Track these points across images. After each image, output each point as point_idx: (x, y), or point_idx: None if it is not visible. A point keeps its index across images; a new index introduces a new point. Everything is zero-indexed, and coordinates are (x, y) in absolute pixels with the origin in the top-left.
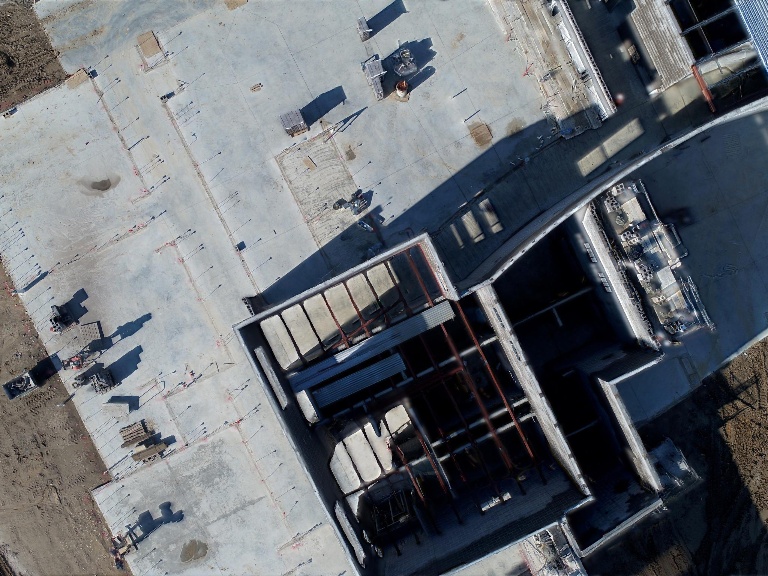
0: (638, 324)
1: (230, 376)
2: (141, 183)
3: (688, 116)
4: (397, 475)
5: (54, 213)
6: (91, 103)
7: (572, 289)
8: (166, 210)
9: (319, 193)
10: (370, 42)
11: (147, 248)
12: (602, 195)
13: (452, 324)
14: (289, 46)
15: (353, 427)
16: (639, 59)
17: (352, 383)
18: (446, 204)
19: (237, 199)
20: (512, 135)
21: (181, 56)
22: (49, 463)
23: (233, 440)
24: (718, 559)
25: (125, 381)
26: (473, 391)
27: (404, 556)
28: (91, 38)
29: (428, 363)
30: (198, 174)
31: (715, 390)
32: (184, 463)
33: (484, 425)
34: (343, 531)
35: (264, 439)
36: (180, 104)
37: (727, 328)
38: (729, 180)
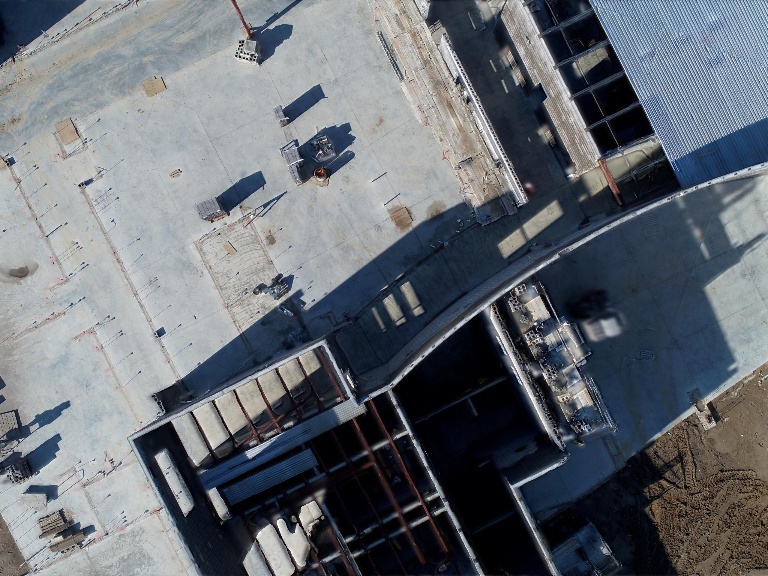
0: (545, 422)
1: None
2: (59, 270)
3: (606, 198)
4: (311, 572)
5: None
6: (9, 190)
7: (494, 372)
8: (85, 297)
9: (239, 278)
10: (289, 127)
11: (66, 335)
12: (505, 295)
13: (364, 418)
14: (208, 132)
15: None
16: (555, 144)
17: (264, 480)
18: (367, 287)
19: (157, 285)
20: (432, 218)
21: (99, 143)
22: None
23: (154, 529)
24: None
25: (43, 470)
26: None
27: None
28: (9, 125)
29: (341, 458)
30: (117, 260)
31: (640, 470)
32: (104, 553)
33: None
34: None
35: None
36: (99, 190)
37: (650, 408)
38: (649, 261)
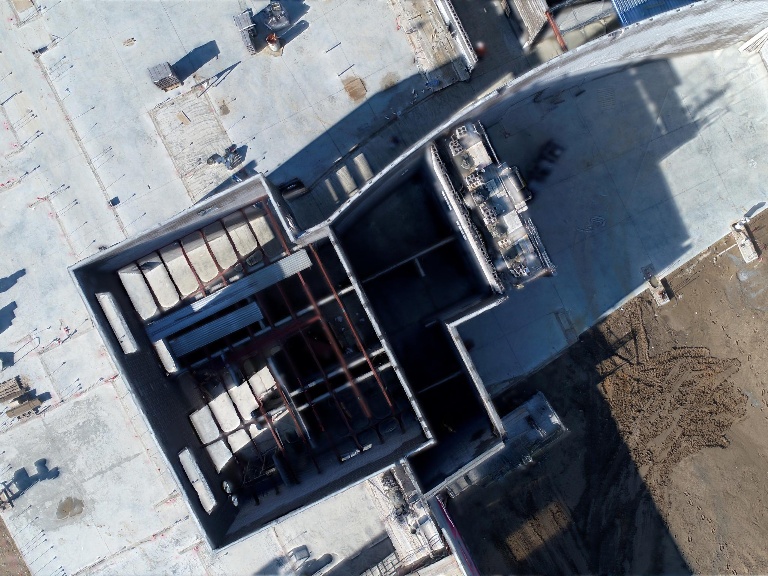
0: (486, 269)
1: None
2: (14, 138)
3: None
4: (256, 425)
5: None
6: None
7: None
8: (40, 165)
9: (193, 148)
10: None
11: (21, 203)
12: (445, 138)
13: (310, 273)
14: (162, 0)
15: (229, 383)
16: (510, 12)
17: (209, 332)
18: (321, 159)
19: (111, 154)
20: (386, 89)
21: (54, 11)
22: None
23: (108, 396)
24: (597, 516)
25: None
26: None
27: (260, 505)
28: None
29: (286, 312)
30: (71, 129)
31: (592, 346)
32: (59, 420)
33: None
34: (185, 475)
35: None
36: (53, 59)
37: (603, 283)
38: (604, 134)
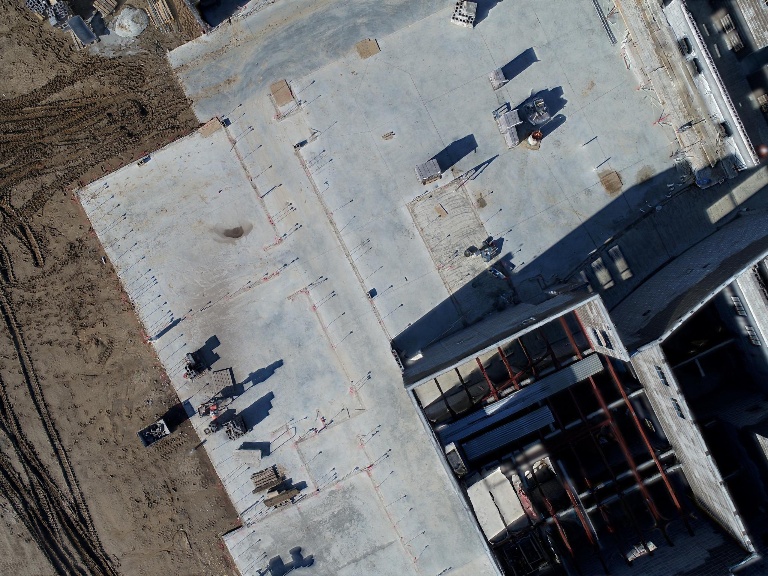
0: None
1: (361, 422)
2: (273, 231)
3: None
4: (544, 526)
5: (187, 260)
6: (224, 151)
7: (702, 335)
8: (298, 257)
9: (450, 240)
10: (501, 91)
11: (279, 295)
12: None
13: (600, 376)
14: (421, 95)
15: (483, 472)
16: None
17: (501, 435)
18: (576, 251)
19: (369, 246)
20: (642, 183)
21: (314, 105)
22: (179, 508)
23: (364, 485)
24: None
25: (256, 427)
26: (621, 443)
27: None
28: (224, 87)
29: (576, 415)
30: (330, 222)
31: None
32: (315, 508)
33: (628, 475)
34: None
35: (394, 484)
36: (312, 152)
37: None
38: None
